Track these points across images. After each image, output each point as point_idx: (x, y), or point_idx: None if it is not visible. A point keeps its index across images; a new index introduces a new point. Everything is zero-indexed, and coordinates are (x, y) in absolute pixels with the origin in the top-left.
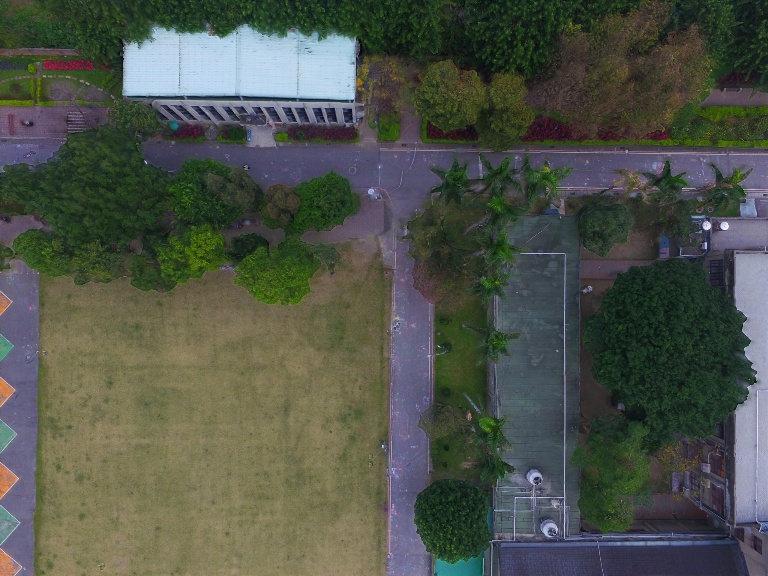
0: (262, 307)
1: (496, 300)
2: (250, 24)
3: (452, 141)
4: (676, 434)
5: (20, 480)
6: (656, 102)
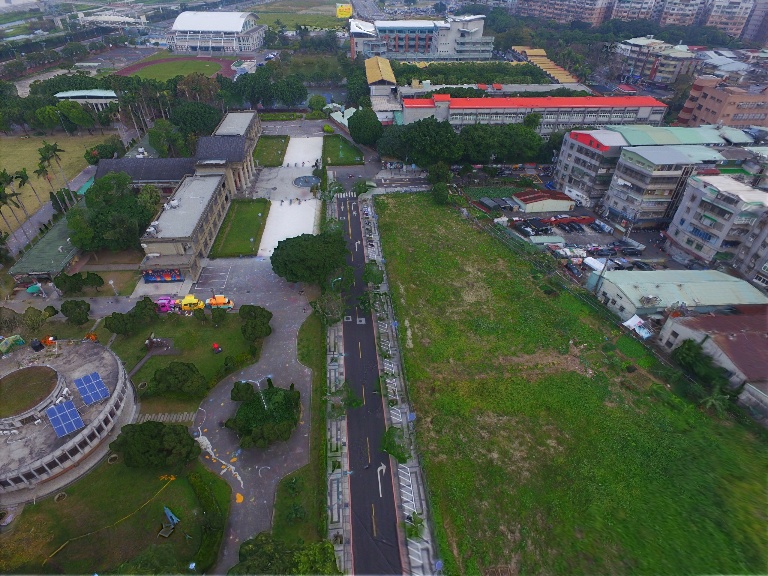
0: None
1: None
2: (97, 88)
3: None
4: (192, 130)
5: None
6: None
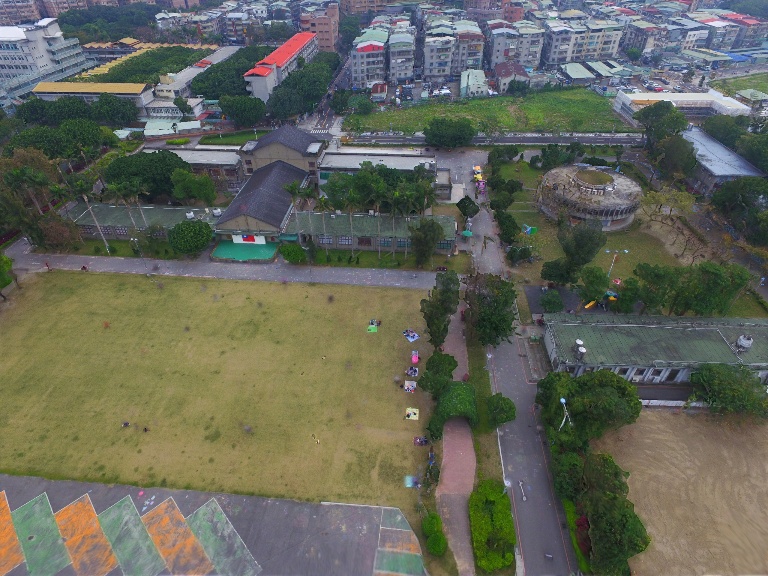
0: (17, 322)
1: (95, 225)
2: None
3: (5, 244)
4: None
5: (6, 490)
6: (37, 164)
